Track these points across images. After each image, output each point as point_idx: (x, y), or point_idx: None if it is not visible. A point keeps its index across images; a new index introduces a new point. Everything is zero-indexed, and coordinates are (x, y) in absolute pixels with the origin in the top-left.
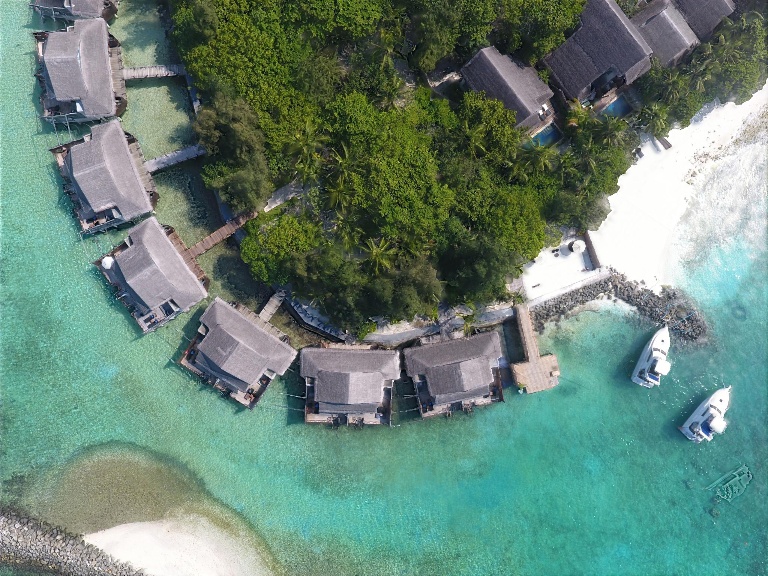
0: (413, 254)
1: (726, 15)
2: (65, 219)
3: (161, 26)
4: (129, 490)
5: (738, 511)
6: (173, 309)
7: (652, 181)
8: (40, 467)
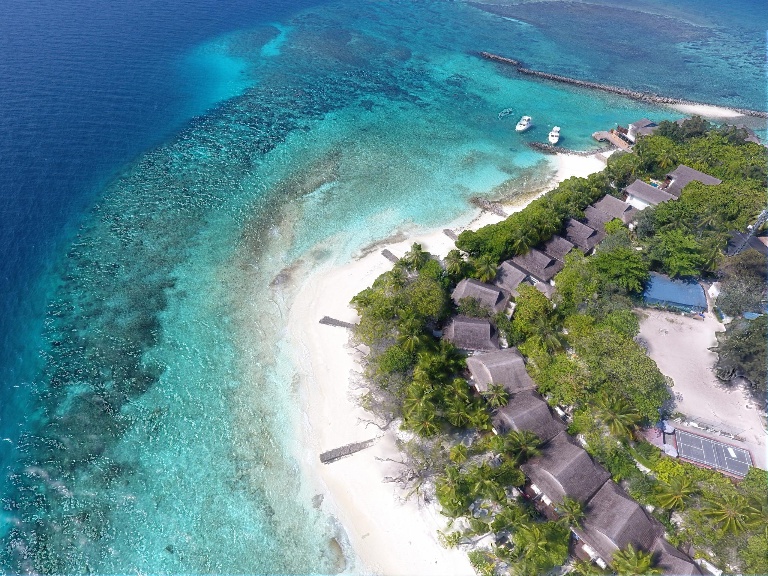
0: None
1: None
2: None
3: None
4: None
5: None
6: None
7: None
8: None
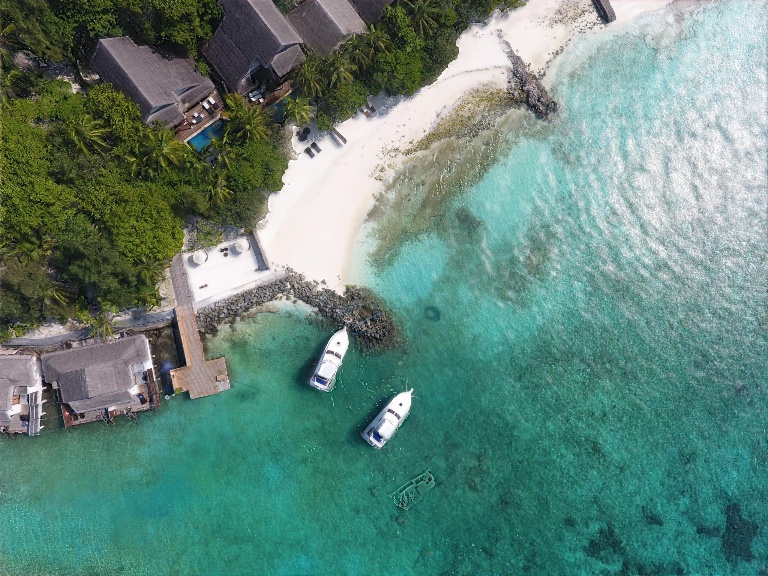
0: (29, 254)
1: (388, 4)
2: None
3: None
4: None
5: (428, 519)
6: None
7: (334, 177)
8: None
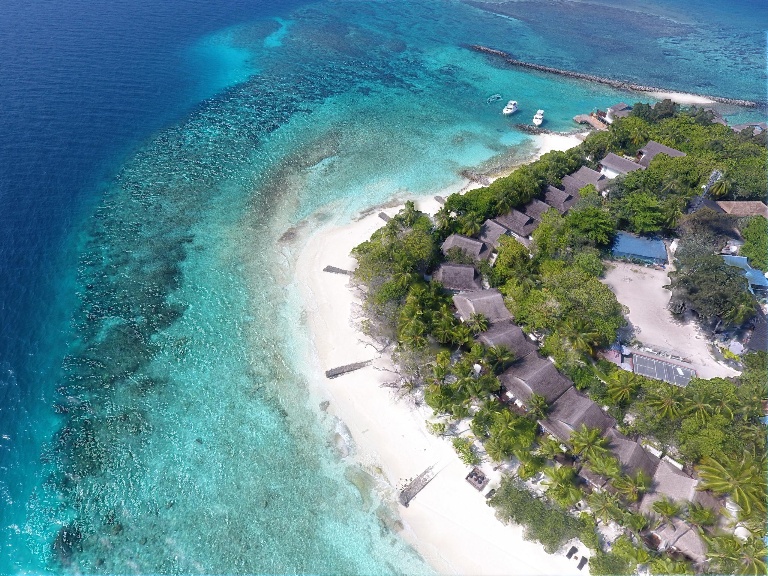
0: None
1: None
2: None
3: None
4: None
5: None
6: None
7: None
8: None
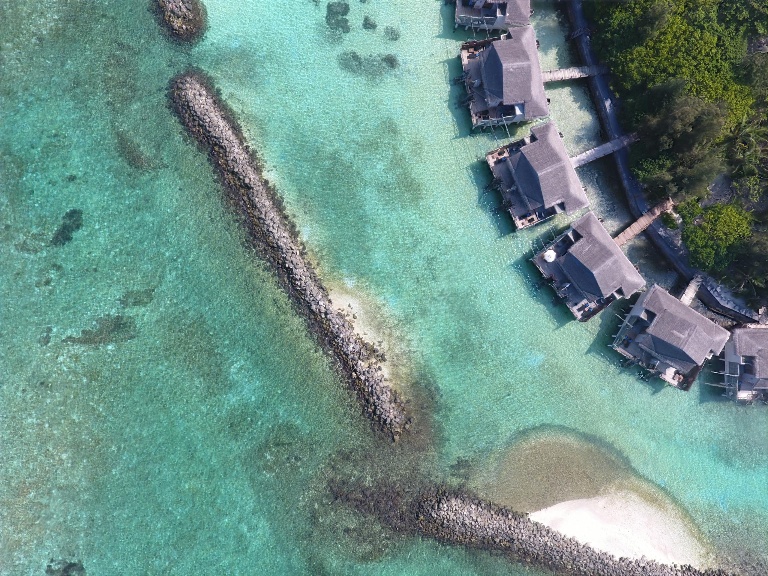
0: None
1: None
2: (485, 217)
3: (560, 30)
4: (565, 470)
5: None
6: (616, 297)
7: None
8: (482, 451)
